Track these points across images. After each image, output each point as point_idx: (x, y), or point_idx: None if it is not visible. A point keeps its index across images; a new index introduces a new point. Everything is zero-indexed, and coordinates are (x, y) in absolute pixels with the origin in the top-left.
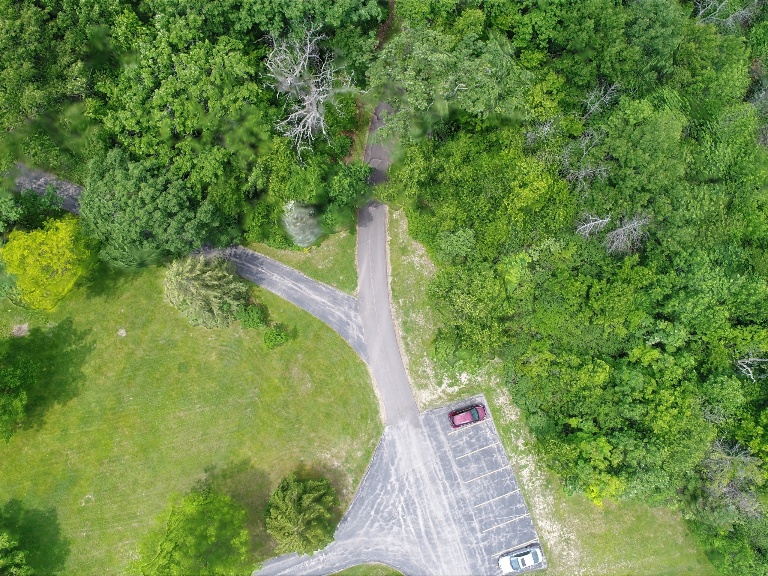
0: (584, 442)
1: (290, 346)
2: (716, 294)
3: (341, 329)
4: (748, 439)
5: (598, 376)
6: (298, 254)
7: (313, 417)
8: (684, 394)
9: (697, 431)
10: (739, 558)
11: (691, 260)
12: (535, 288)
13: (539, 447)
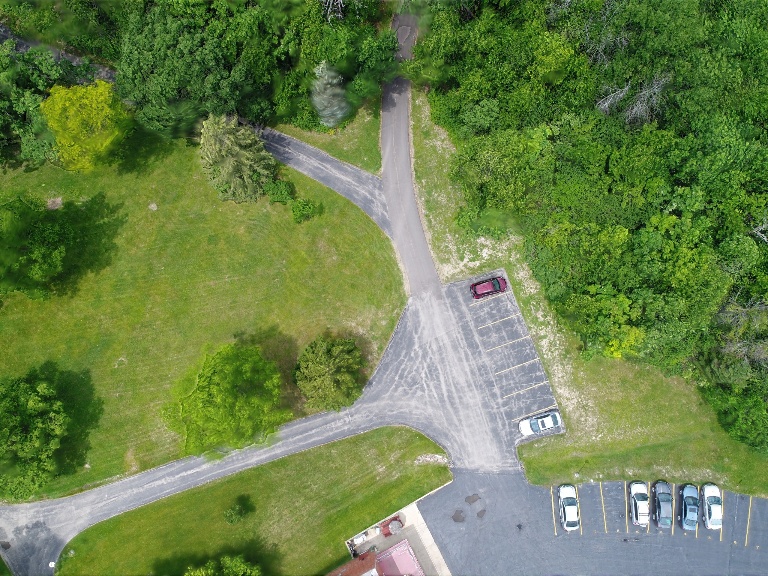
0: (604, 300)
1: (316, 221)
2: (733, 149)
3: (366, 206)
4: (763, 292)
5: (618, 235)
6: (324, 136)
7: (339, 287)
8: (701, 254)
9: (714, 280)
10: (753, 413)
11: (709, 118)
12: (556, 159)
13: (558, 319)
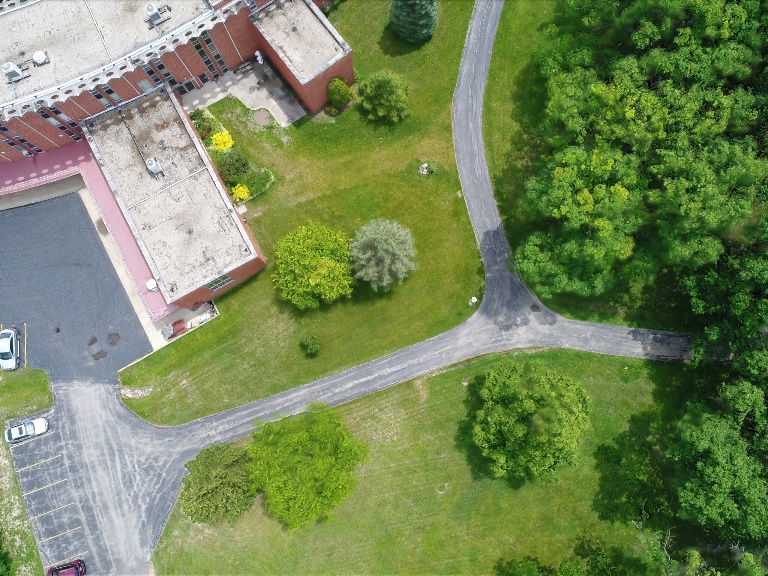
0: None
1: None
2: None
3: None
4: None
5: None
6: None
7: (221, 572)
8: None
9: None
10: None
11: None
12: None
13: (0, 538)
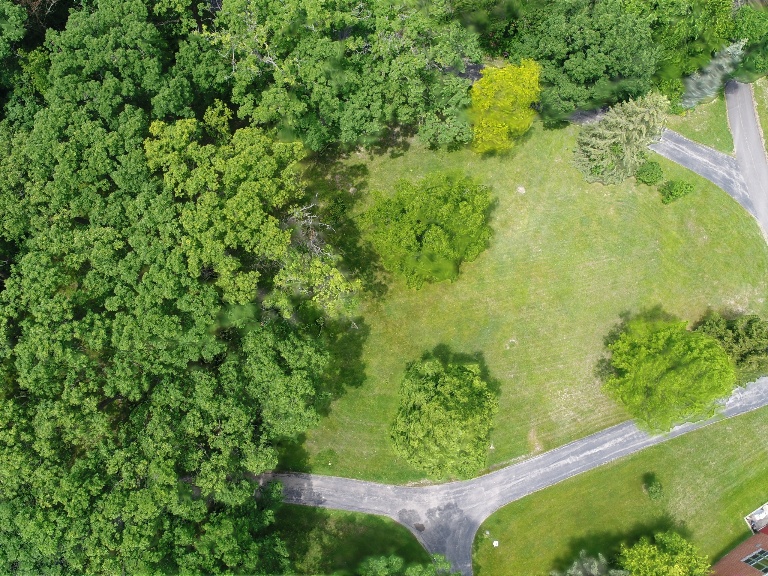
0: None
1: (681, 202)
2: None
3: (726, 186)
4: None
5: None
6: (675, 118)
7: (714, 266)
8: None
9: None
10: None
11: None
12: None
13: None
